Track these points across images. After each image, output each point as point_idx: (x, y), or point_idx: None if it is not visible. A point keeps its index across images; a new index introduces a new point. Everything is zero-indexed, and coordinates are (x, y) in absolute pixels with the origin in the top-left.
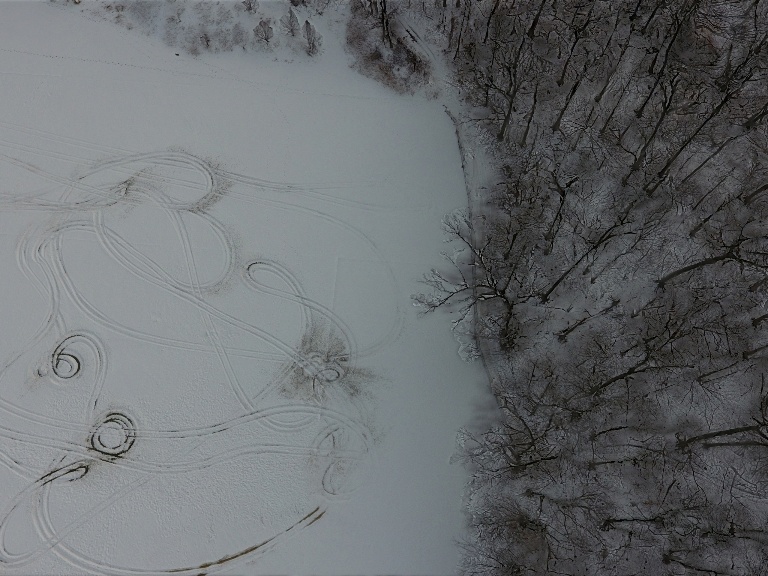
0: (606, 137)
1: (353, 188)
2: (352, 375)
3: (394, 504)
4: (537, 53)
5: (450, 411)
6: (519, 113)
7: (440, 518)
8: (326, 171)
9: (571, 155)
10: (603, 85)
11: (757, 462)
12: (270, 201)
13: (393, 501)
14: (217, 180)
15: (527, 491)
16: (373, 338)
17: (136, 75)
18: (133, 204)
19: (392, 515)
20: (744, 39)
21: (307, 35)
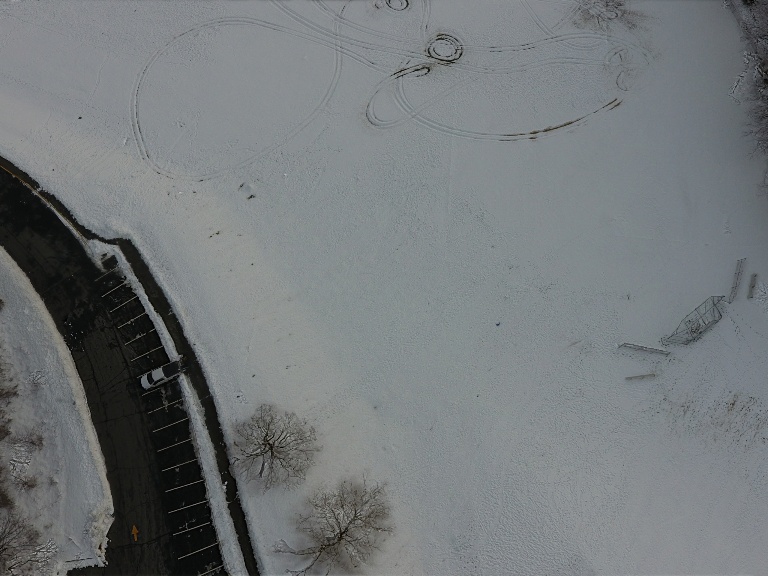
0: None
1: None
2: (628, 15)
3: (675, 98)
4: None
5: (710, 40)
6: None
7: (713, 108)
8: None
9: None
10: None
11: None
12: None
13: (674, 96)
14: None
15: None
16: None
17: None
18: None
19: (675, 105)
20: None
21: None
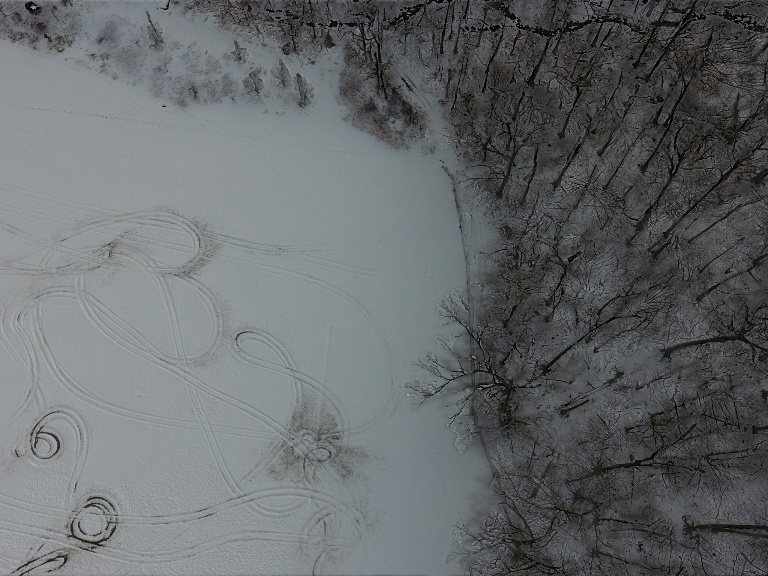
0: (609, 194)
1: (346, 250)
2: (344, 455)
3: None
4: (537, 104)
5: (447, 494)
6: (519, 168)
7: None
8: (318, 232)
9: (573, 214)
10: (606, 140)
11: None
12: (259, 265)
13: None
14: (204, 242)
15: None
16: (366, 414)
17: (121, 128)
18: (117, 268)
19: None
20: (752, 87)
21: (298, 87)
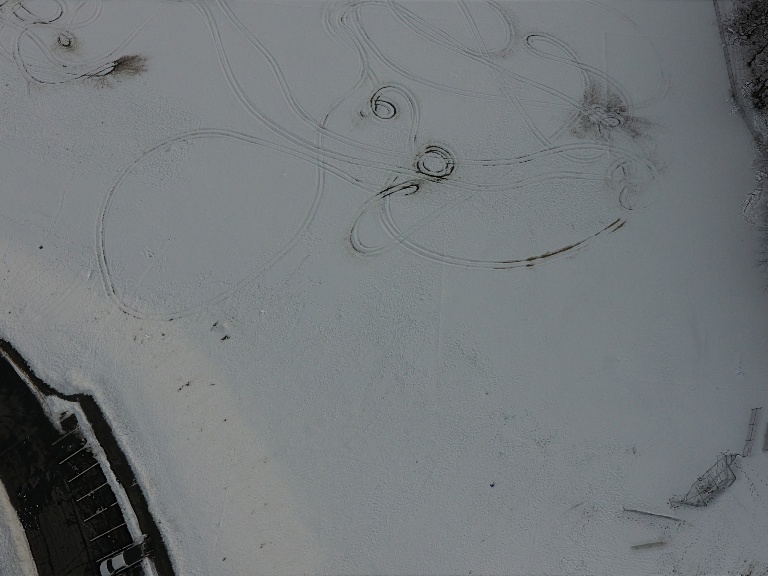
0: None
1: None
2: (632, 122)
3: (683, 217)
4: None
5: (719, 151)
6: None
7: (723, 228)
8: None
9: None
10: None
11: None
12: None
13: (682, 215)
14: None
15: None
16: (645, 95)
17: None
18: None
19: (682, 225)
20: None
21: None
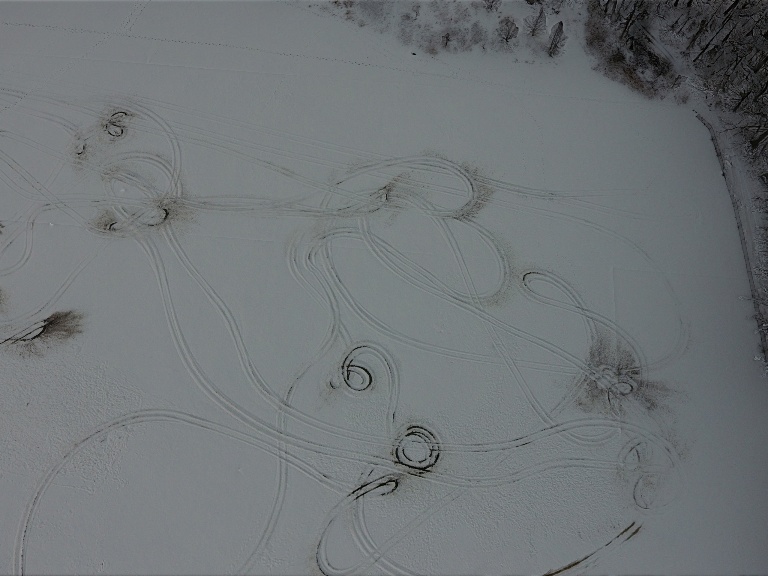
0: None
1: (616, 196)
2: (646, 388)
3: (708, 519)
4: None
5: (749, 425)
6: None
7: (756, 533)
8: (586, 178)
9: None
10: None
11: None
12: (534, 209)
13: (707, 516)
14: (477, 186)
15: None
16: (661, 351)
17: (376, 75)
18: (396, 211)
19: (708, 530)
20: None
21: (554, 36)
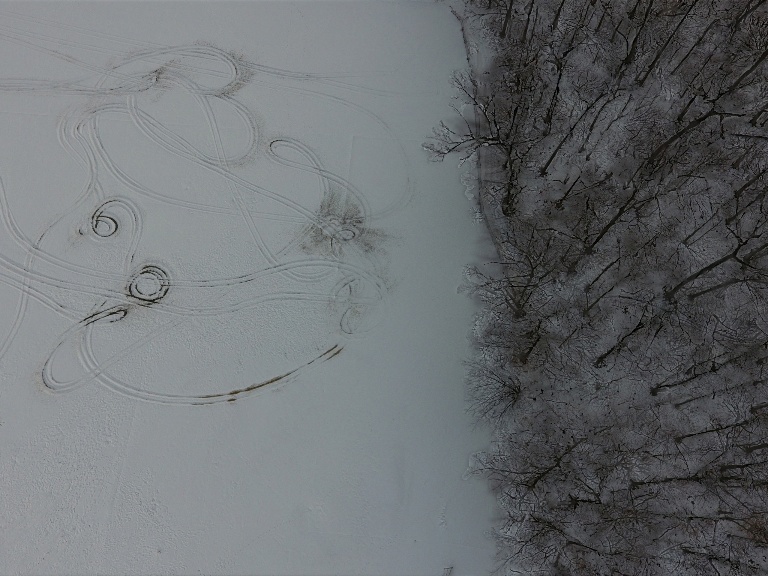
0: (601, 35)
1: (366, 77)
2: (367, 235)
3: (406, 342)
4: None
5: (457, 265)
6: (520, 14)
7: (448, 354)
8: (341, 62)
9: None
10: None
11: (737, 311)
12: (290, 88)
13: (405, 340)
14: (241, 70)
15: (527, 333)
16: (386, 204)
17: None
18: (163, 90)
19: (404, 351)
20: None
21: None
